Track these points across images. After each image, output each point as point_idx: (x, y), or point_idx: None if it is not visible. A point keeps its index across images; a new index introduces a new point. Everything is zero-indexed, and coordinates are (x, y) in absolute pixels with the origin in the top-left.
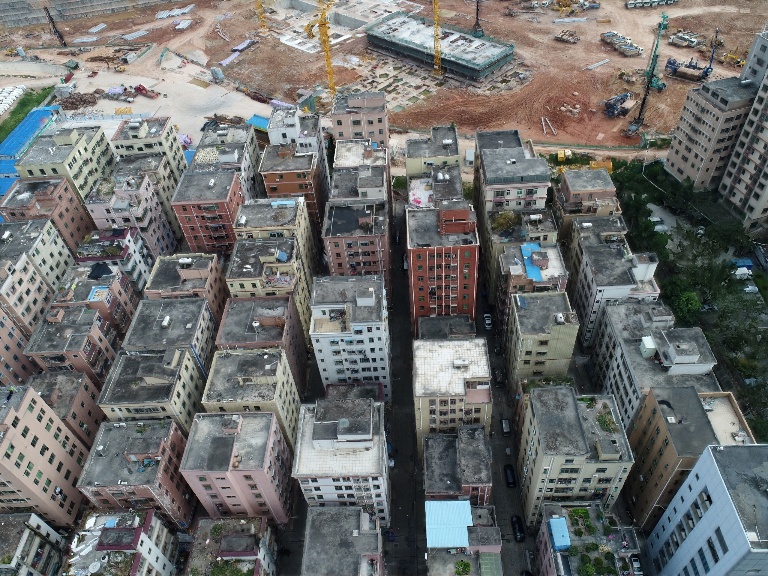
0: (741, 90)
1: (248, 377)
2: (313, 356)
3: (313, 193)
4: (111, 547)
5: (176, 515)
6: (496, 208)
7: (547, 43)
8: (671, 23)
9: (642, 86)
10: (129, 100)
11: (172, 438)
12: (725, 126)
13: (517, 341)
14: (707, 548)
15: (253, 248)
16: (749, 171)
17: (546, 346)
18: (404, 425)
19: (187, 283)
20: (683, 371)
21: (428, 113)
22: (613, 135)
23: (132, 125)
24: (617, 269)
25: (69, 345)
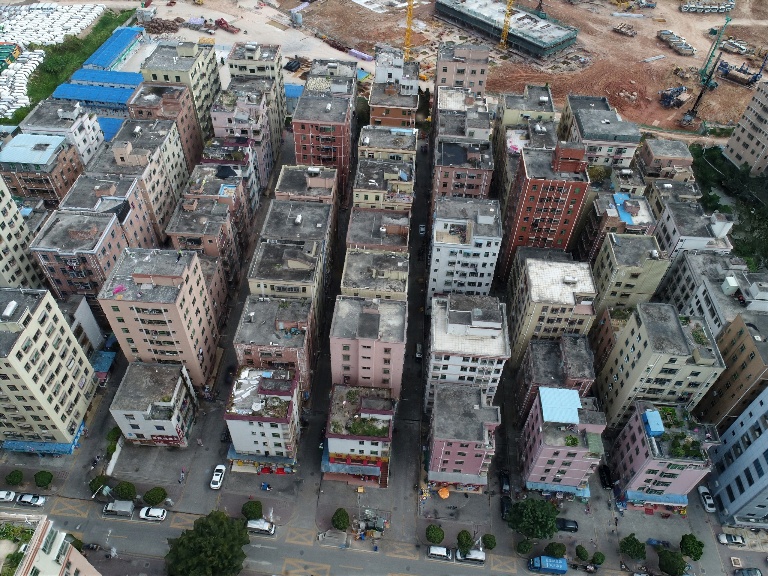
0: None
1: (383, 270)
2: None
3: None
4: (272, 392)
5: (305, 384)
6: None
7: (606, 33)
8: None
9: (695, 83)
10: (211, 32)
11: (311, 315)
12: None
13: (610, 272)
14: None
15: (375, 166)
16: None
17: (636, 279)
18: None
19: (312, 190)
20: (760, 308)
21: (494, 82)
22: (668, 123)
23: (249, 47)
24: (697, 224)
25: (207, 230)
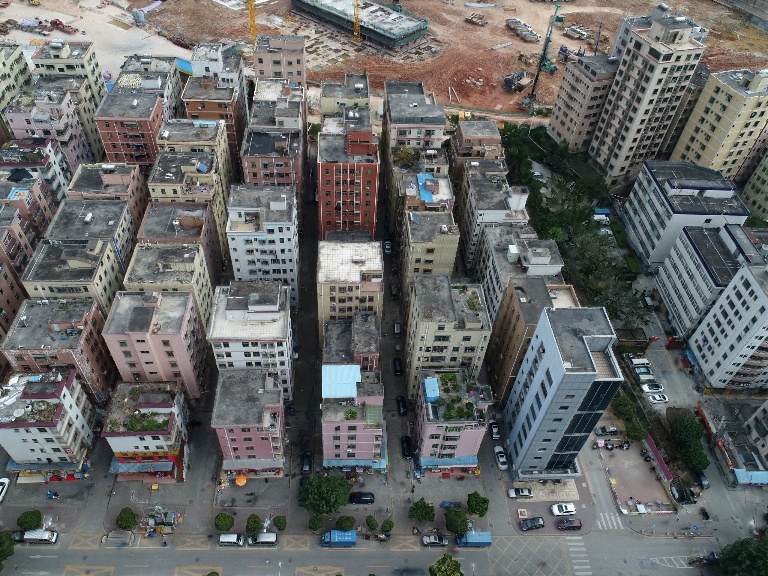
0: (608, 65)
1: (168, 263)
2: (227, 269)
3: (233, 124)
4: (35, 396)
5: (95, 386)
6: (399, 146)
7: (458, 23)
8: (567, 17)
9: None
10: (44, 33)
11: (94, 314)
12: (594, 94)
13: (409, 250)
14: (541, 389)
15: (175, 160)
16: (611, 134)
17: (432, 254)
18: (309, 327)
19: (109, 188)
20: (538, 272)
21: None
22: (509, 107)
23: (54, 45)
24: (496, 198)
25: None
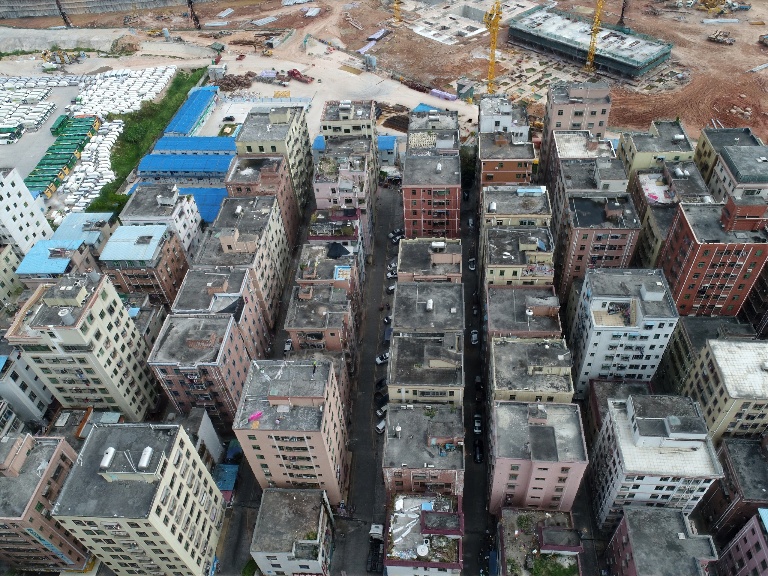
0: None
1: (542, 366)
2: None
3: None
4: (438, 531)
5: None
6: None
7: (700, 43)
8: None
9: None
10: (285, 84)
11: None
12: None
13: None
14: None
15: (506, 235)
16: None
17: None
18: None
19: (438, 267)
20: None
21: None
22: None
23: (344, 106)
24: None
25: (329, 323)
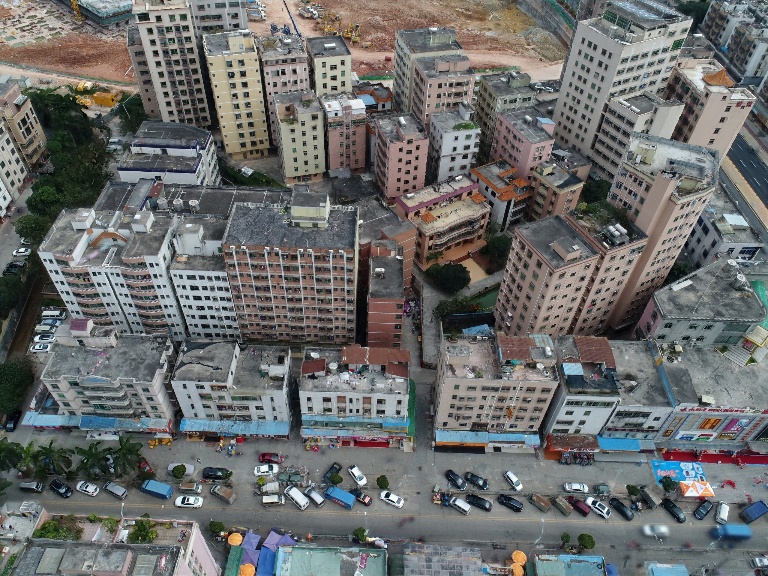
0: None
1: None
2: None
3: None
4: None
5: None
6: None
7: None
8: None
9: None
10: None
11: None
12: (139, 59)
13: None
14: None
15: None
16: None
17: None
18: None
19: None
20: None
21: (41, 51)
22: None
23: None
24: None
25: None
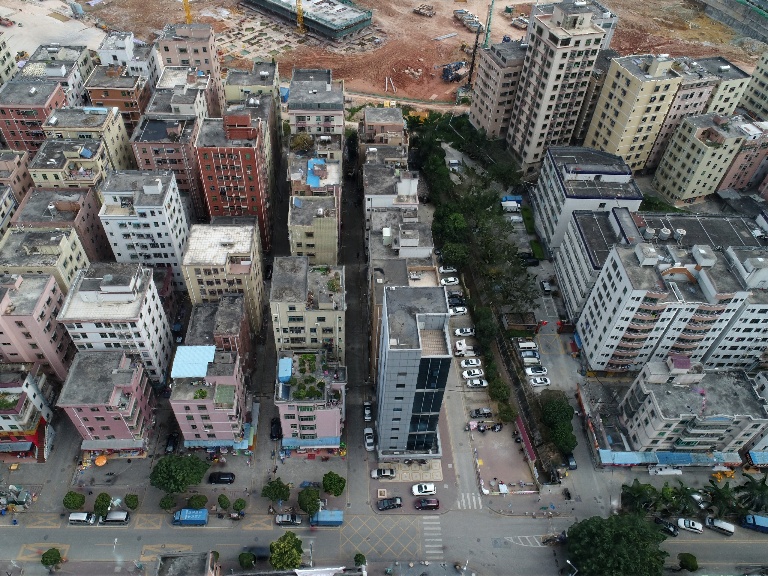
0: (519, 52)
1: (33, 246)
2: None
3: (139, 112)
4: None
5: None
6: (299, 133)
7: (406, 14)
8: (517, 8)
9: None
10: None
11: None
12: (505, 81)
13: None
14: None
15: (61, 146)
16: (523, 121)
17: (312, 238)
18: None
19: None
20: (410, 254)
21: (285, 65)
22: (445, 96)
23: None
24: (386, 183)
25: None
